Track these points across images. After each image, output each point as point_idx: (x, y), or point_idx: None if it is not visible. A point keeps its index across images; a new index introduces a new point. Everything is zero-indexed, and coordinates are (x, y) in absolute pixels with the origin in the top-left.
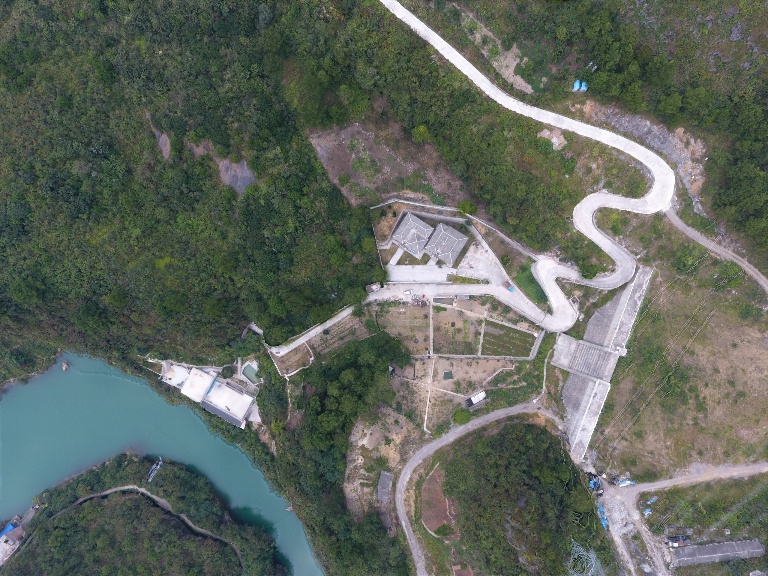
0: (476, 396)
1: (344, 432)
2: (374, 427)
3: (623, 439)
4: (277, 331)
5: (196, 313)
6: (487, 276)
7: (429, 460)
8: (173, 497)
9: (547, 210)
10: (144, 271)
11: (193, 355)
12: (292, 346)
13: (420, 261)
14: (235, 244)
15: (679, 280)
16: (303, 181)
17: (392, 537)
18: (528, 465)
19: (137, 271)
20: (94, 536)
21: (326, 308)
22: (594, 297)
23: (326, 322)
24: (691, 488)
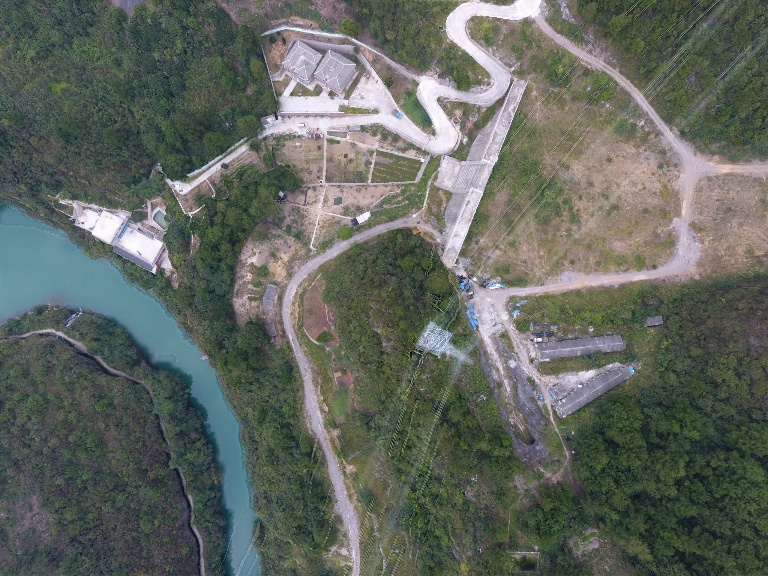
0: (361, 216)
1: (233, 249)
2: (263, 247)
3: (497, 248)
4: (172, 157)
5: (96, 143)
6: (377, 106)
7: (313, 274)
8: (87, 337)
9: (418, 16)
10: (40, 92)
11: (101, 195)
12: (194, 183)
13: (313, 92)
14: (130, 71)
15: (553, 92)
16: (189, 0)
17: (278, 349)
18: (394, 258)
19: (33, 92)
20: (8, 367)
21: (218, 134)
22: (473, 115)
23: (226, 158)
24: (562, 295)
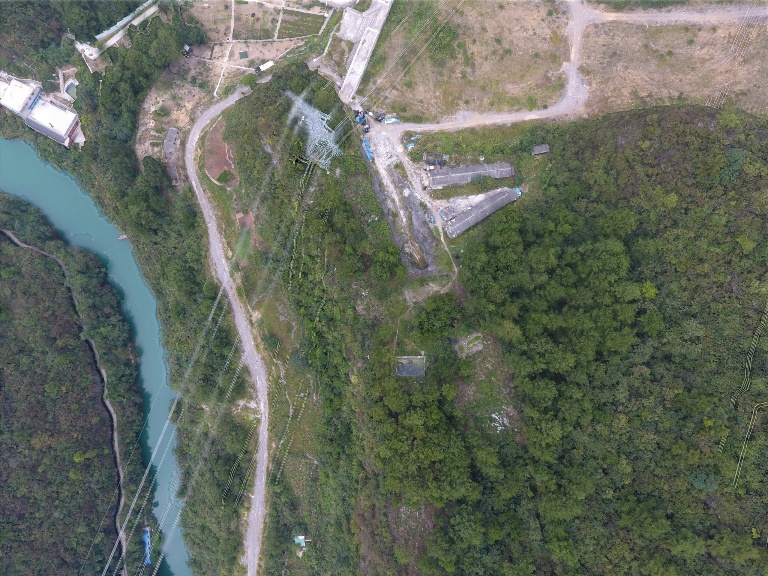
0: (264, 65)
1: (136, 97)
2: (167, 96)
3: (394, 89)
4: (75, 9)
5: None
6: None
7: (215, 118)
8: None
9: None
10: None
11: (9, 60)
12: (104, 47)
13: None
14: None
15: None
16: None
17: None
18: None
19: None
20: None
21: None
22: None
23: (135, 20)
24: (457, 132)
